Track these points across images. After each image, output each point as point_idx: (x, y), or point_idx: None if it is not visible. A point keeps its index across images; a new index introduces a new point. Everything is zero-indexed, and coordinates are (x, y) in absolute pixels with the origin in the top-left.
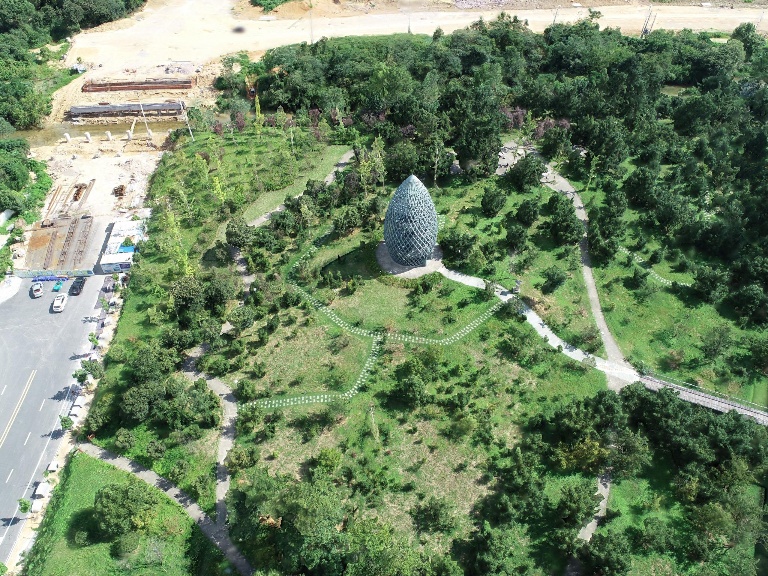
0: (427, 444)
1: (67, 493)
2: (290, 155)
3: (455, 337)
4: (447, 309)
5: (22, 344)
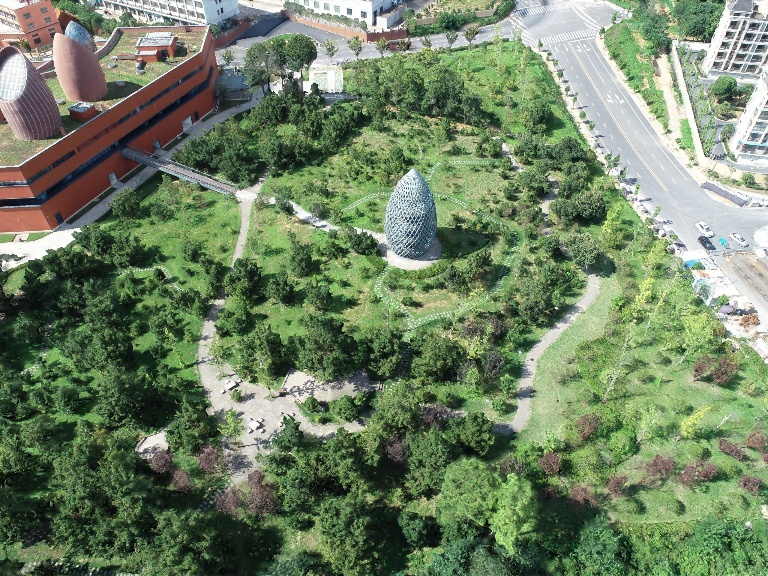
0: (386, 151)
1: (576, 133)
2: (608, 398)
3: (367, 198)
4: (373, 210)
5: (697, 205)
